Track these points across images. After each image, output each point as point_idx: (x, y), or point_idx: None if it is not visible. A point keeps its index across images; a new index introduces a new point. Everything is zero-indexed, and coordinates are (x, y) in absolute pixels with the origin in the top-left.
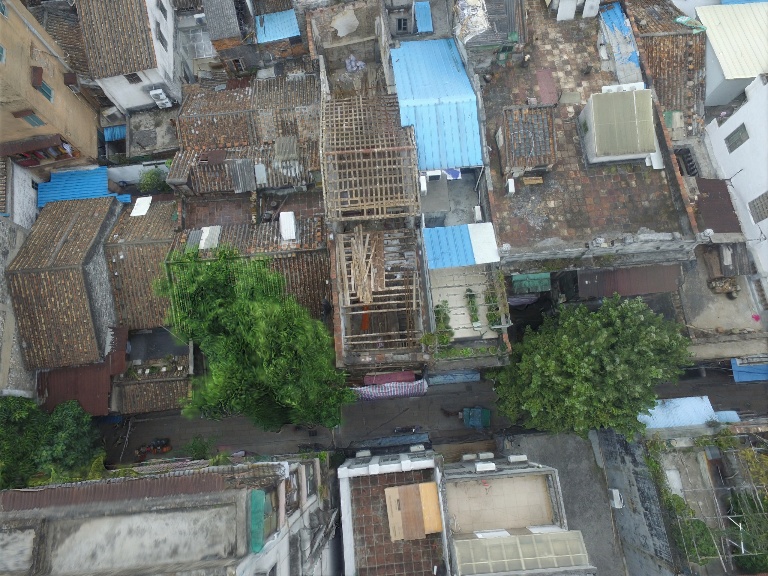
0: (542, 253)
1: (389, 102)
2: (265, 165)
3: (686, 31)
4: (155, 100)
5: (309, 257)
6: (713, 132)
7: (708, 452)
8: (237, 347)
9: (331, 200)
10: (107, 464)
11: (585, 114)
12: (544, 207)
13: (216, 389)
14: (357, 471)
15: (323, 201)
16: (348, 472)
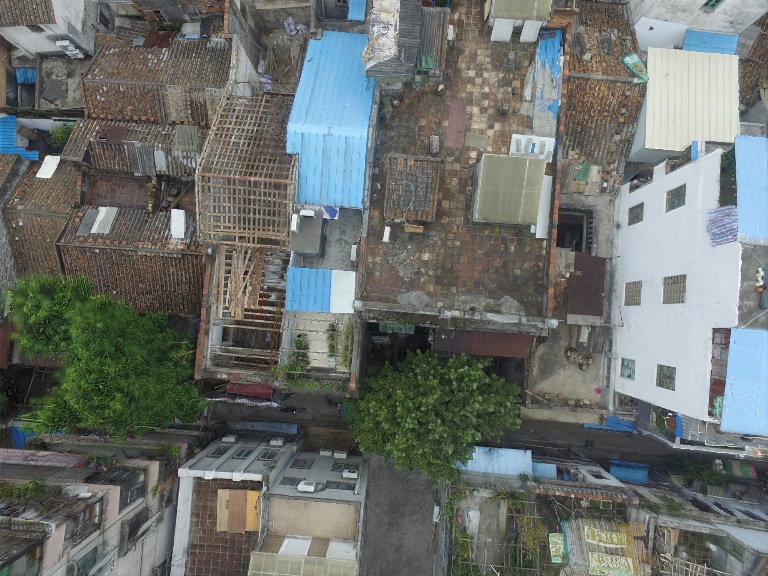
0: None
1: None
2: (165, 152)
3: (626, 79)
4: (64, 50)
5: (194, 260)
6: (624, 196)
7: None
8: None
9: (204, 222)
10: (15, 402)
11: (478, 170)
12: (418, 258)
13: (51, 410)
14: (195, 473)
15: None
16: (188, 472)
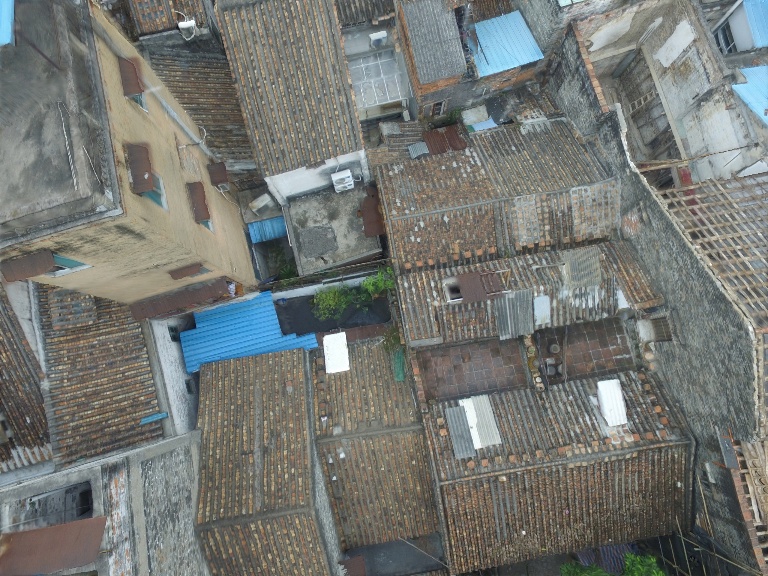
0: None
1: None
2: (549, 296)
3: None
4: (335, 185)
5: (656, 454)
6: None
7: None
8: None
9: (767, 409)
10: None
11: None
12: None
13: None
14: None
15: (639, 344)
16: None
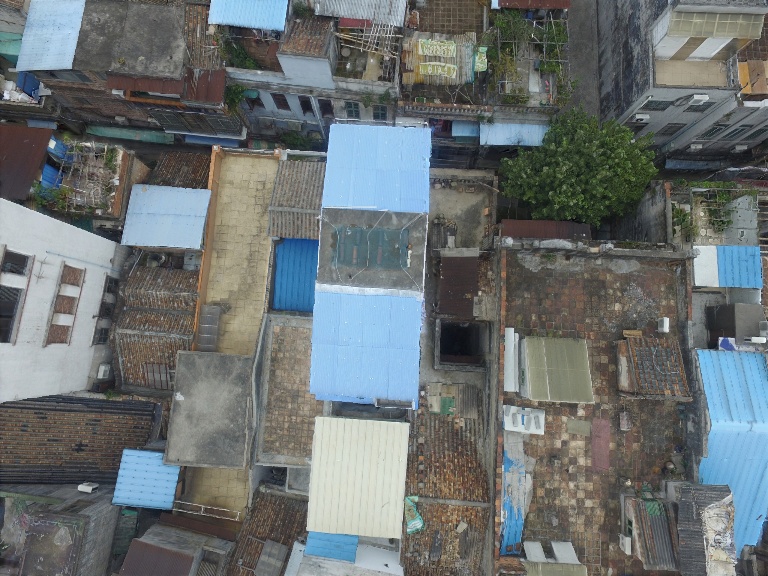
0: None
1: None
2: None
3: (426, 501)
4: None
5: None
6: None
7: None
8: None
9: None
10: None
11: None
12: (625, 305)
13: None
14: None
15: None
16: None
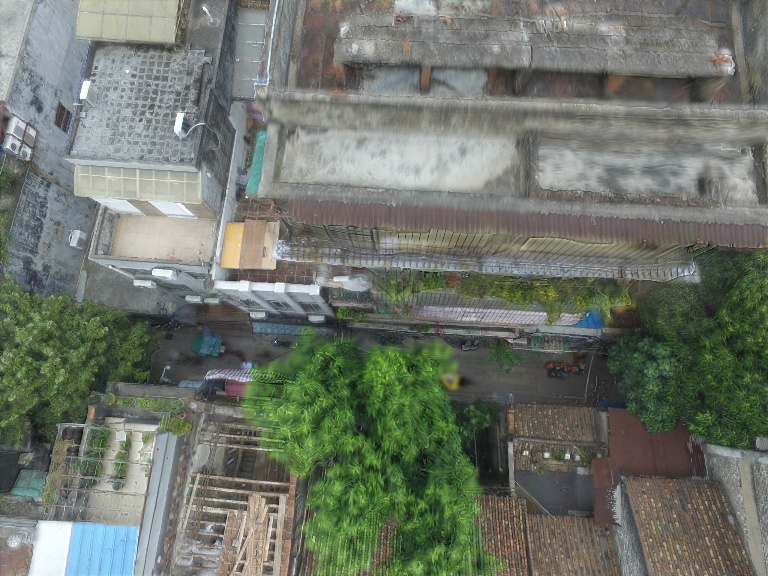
0: None
1: None
2: None
3: None
4: None
5: None
6: None
7: None
8: (394, 448)
9: None
10: None
11: None
12: None
13: None
14: (299, 289)
15: None
16: (309, 290)
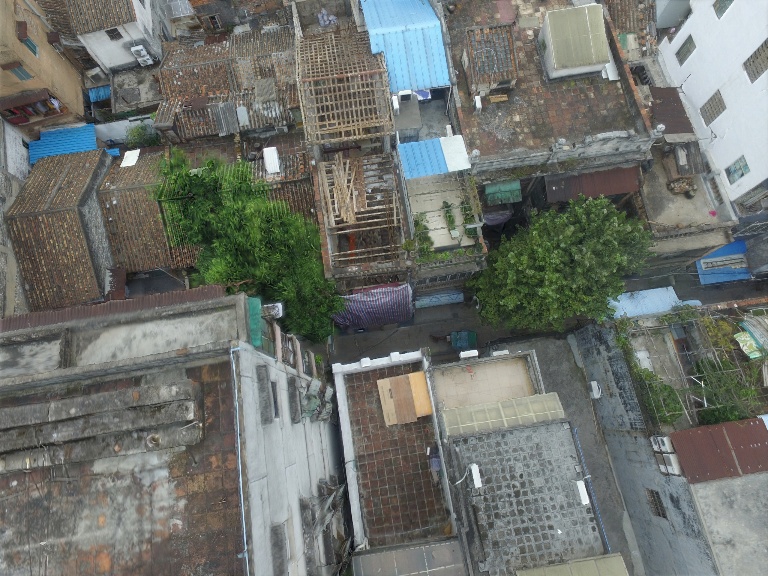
0: (510, 160)
1: (360, 38)
2: (246, 107)
3: None
4: (136, 57)
5: (294, 187)
6: (665, 50)
7: (674, 333)
8: (230, 248)
9: (310, 124)
10: None
11: (543, 33)
12: (510, 121)
13: None
14: (350, 366)
15: None
16: (342, 367)
